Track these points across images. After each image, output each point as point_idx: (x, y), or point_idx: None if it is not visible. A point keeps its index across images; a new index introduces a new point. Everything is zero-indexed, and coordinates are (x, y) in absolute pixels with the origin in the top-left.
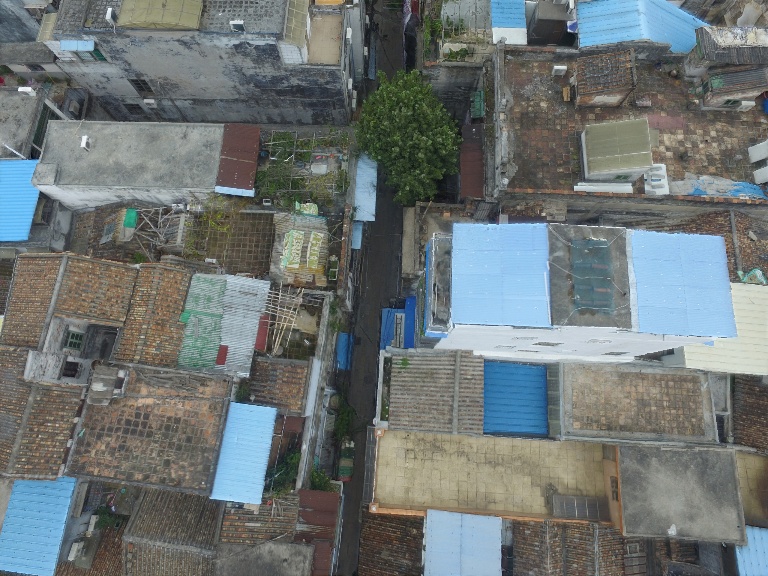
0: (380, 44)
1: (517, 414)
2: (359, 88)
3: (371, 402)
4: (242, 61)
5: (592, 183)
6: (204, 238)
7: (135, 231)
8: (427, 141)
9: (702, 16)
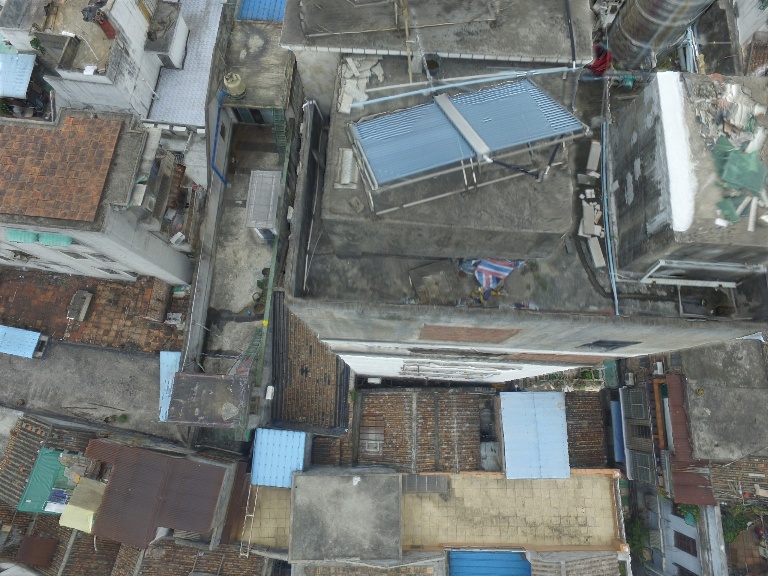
0: None
1: (482, 572)
2: None
3: None
4: None
5: None
6: None
7: None
8: None
9: None
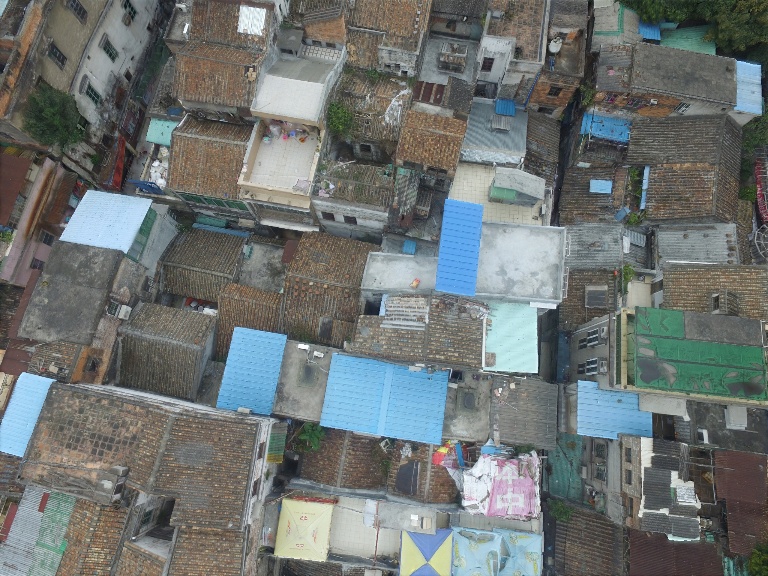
0: None
1: None
2: None
3: None
4: None
5: None
6: None
7: None
8: None
9: None
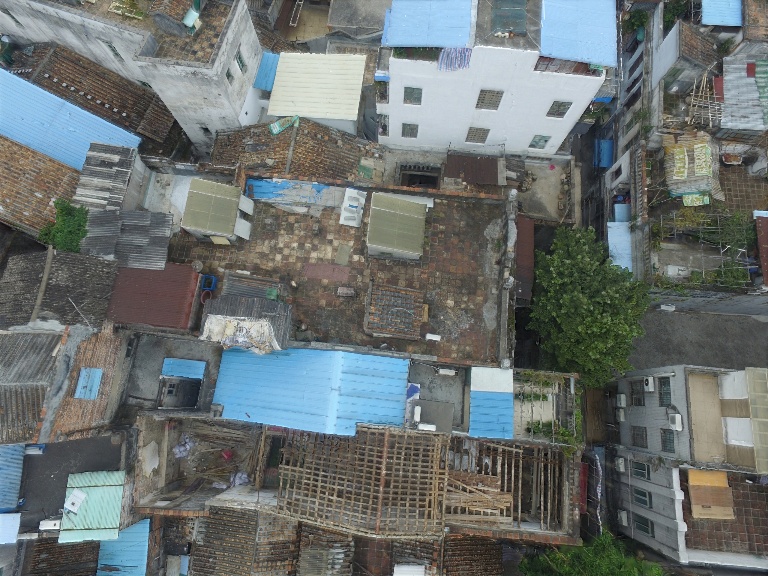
0: None
1: None
2: None
3: None
4: None
5: None
6: None
7: None
8: (582, 259)
9: (188, 492)
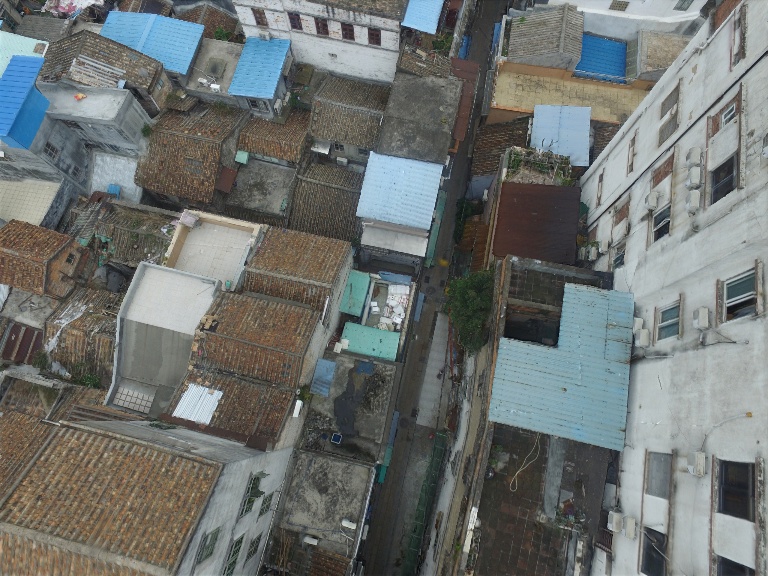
0: None
1: (603, 68)
2: None
3: None
4: None
5: None
6: None
7: None
8: None
9: None
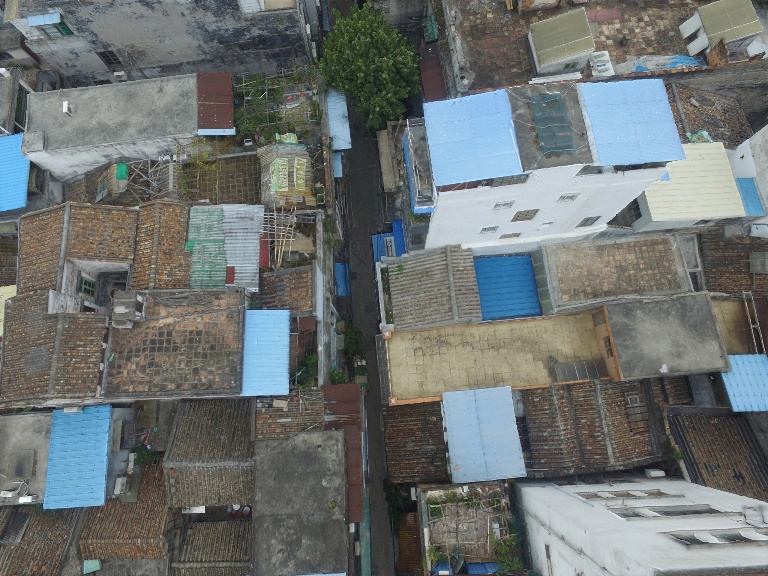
0: (330, 3)
1: (511, 300)
2: (317, 42)
3: (375, 328)
4: (203, 16)
5: (544, 77)
6: (195, 179)
7: (128, 182)
8: (388, 61)
9: None
